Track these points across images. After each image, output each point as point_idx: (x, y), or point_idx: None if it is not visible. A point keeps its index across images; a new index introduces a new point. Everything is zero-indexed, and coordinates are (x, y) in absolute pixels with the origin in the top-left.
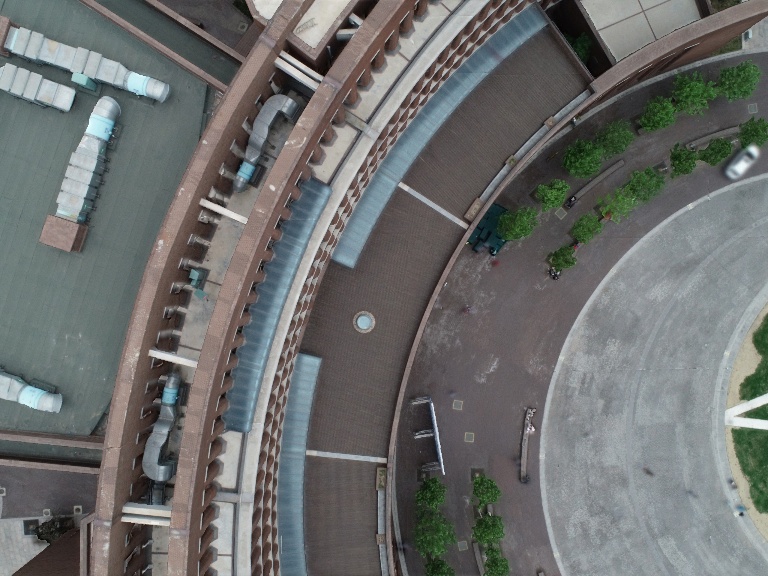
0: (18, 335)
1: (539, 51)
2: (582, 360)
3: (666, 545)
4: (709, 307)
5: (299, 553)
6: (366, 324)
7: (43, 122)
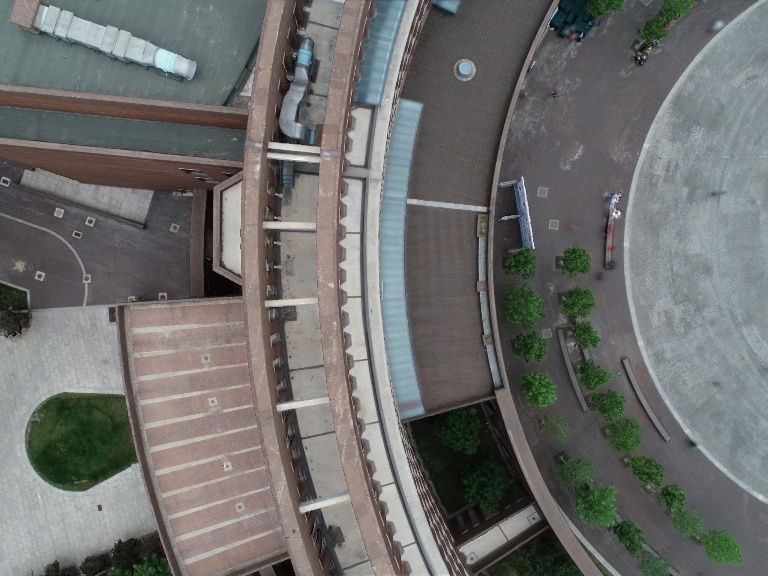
0: (149, 7)
1: None
2: (667, 148)
3: (750, 334)
4: None
5: (400, 299)
6: (467, 70)
7: None
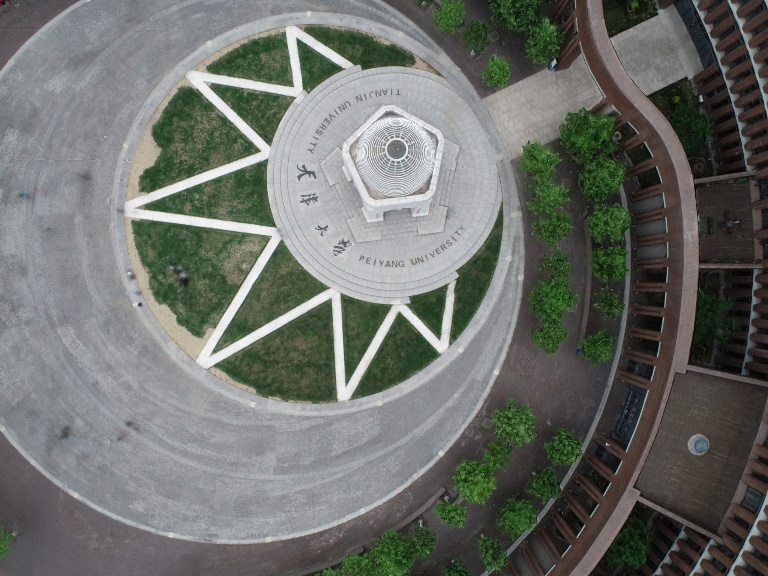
0: None
1: None
2: None
3: (65, 334)
4: (108, 99)
5: None
6: None
7: None
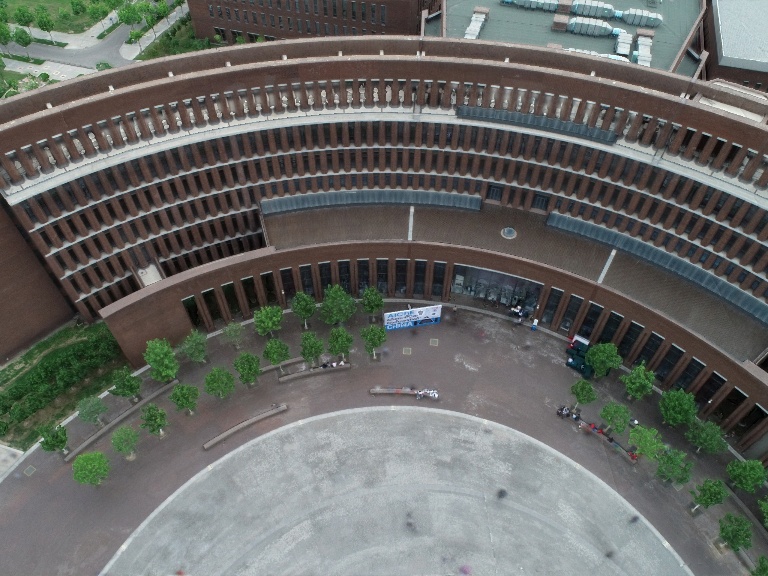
0: None
1: (756, 332)
2: (486, 440)
3: (303, 529)
4: (564, 570)
5: (344, 201)
6: (509, 232)
7: (606, 52)
